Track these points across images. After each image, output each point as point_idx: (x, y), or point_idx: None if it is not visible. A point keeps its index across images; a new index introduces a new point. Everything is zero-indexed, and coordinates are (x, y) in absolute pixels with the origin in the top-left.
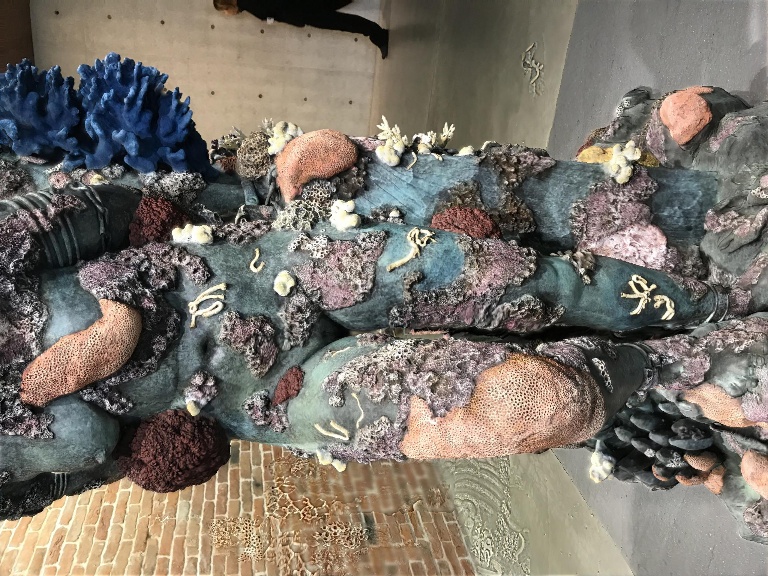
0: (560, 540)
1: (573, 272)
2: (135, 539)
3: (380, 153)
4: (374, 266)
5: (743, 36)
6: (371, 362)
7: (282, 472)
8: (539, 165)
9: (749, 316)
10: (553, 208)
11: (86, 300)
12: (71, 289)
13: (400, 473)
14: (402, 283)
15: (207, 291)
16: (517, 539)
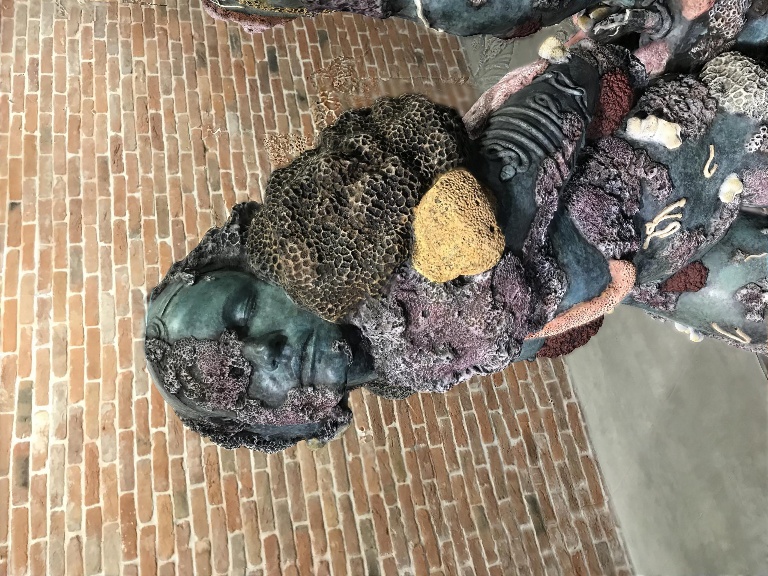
0: None
1: None
2: (193, 151)
3: None
4: None
5: None
6: None
7: (325, 86)
8: None
9: None
10: None
11: (598, 261)
12: (580, 246)
13: (442, 95)
14: None
15: (668, 210)
16: None
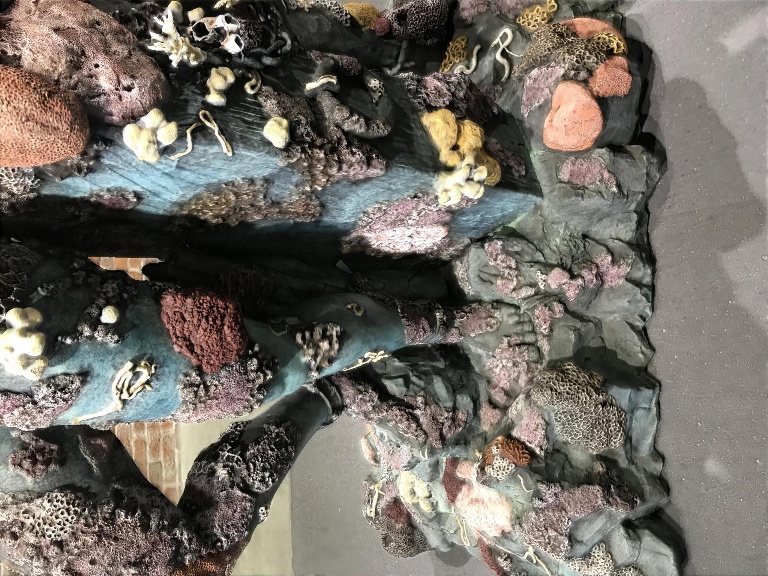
0: None
1: (304, 378)
2: None
3: (129, 145)
4: (51, 421)
5: (727, 16)
6: (17, 519)
7: None
8: (363, 174)
9: (439, 382)
10: (351, 204)
11: None
12: None
13: None
14: (87, 424)
15: None
16: None
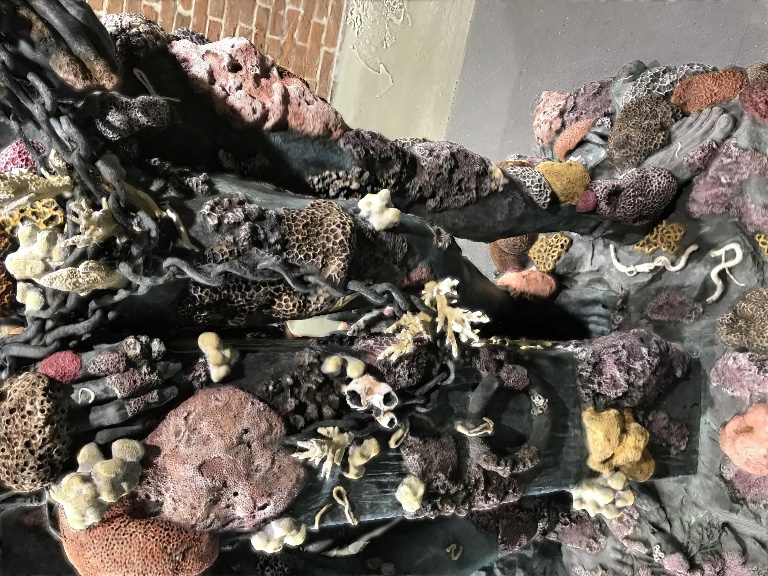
0: (421, 86)
1: None
2: None
3: None
4: None
5: None
6: None
7: None
8: None
9: None
10: None
11: None
12: None
13: None
14: None
15: None
16: (399, 8)
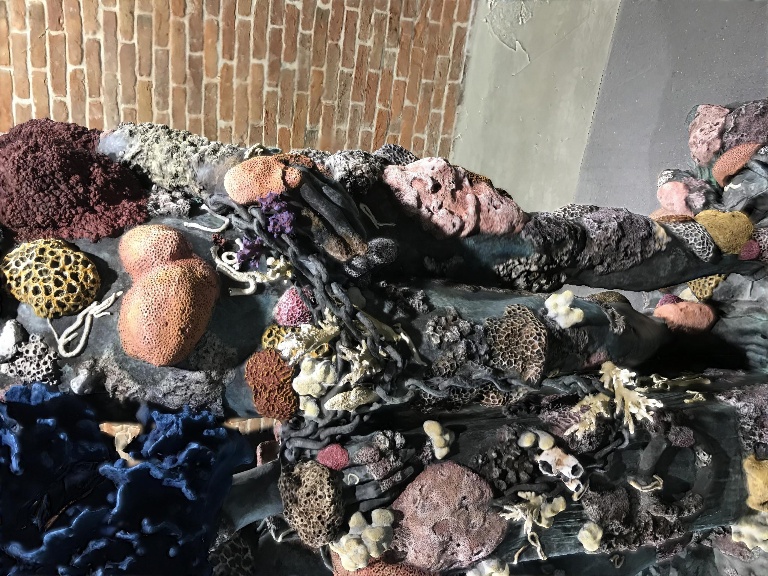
0: (560, 67)
1: None
2: None
3: None
4: None
5: None
6: None
7: None
8: None
9: None
10: None
11: None
12: None
13: None
14: None
15: None
16: None
